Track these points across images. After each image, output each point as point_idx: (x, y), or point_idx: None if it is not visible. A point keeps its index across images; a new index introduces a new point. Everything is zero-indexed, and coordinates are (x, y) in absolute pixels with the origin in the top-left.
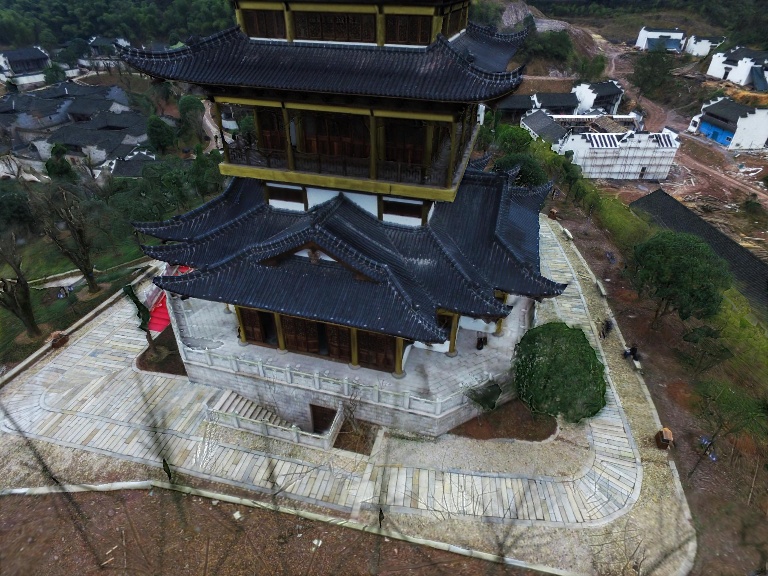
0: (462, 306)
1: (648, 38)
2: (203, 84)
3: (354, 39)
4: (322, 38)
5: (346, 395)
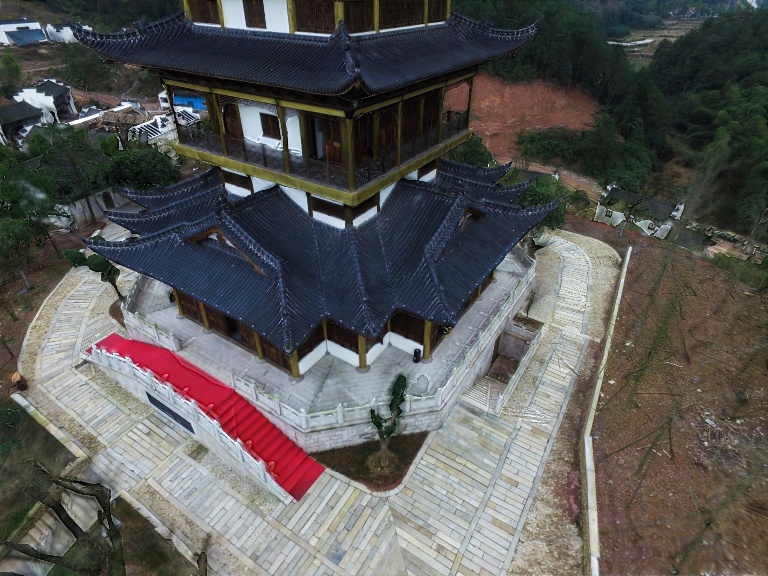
0: (505, 202)
1: (5, 32)
2: (392, 90)
3: (411, 22)
4: (394, 25)
5: (511, 307)
